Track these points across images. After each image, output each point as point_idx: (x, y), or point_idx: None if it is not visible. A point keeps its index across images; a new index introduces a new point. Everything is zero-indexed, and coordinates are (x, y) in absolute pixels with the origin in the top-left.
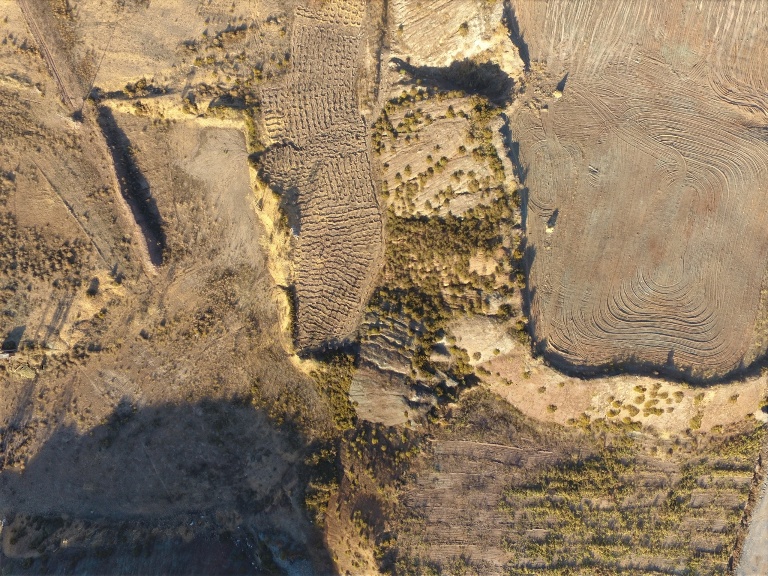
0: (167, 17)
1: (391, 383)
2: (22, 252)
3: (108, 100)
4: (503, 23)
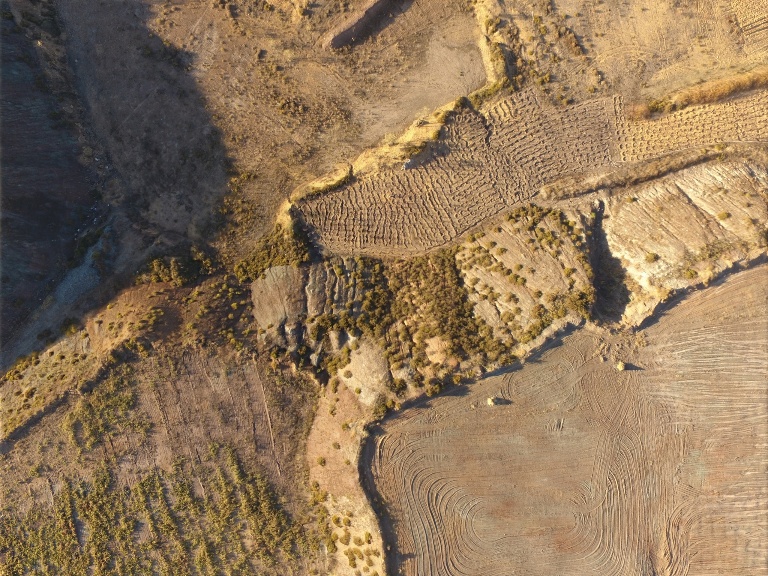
0: None
1: (295, 302)
2: None
3: None
4: (671, 292)
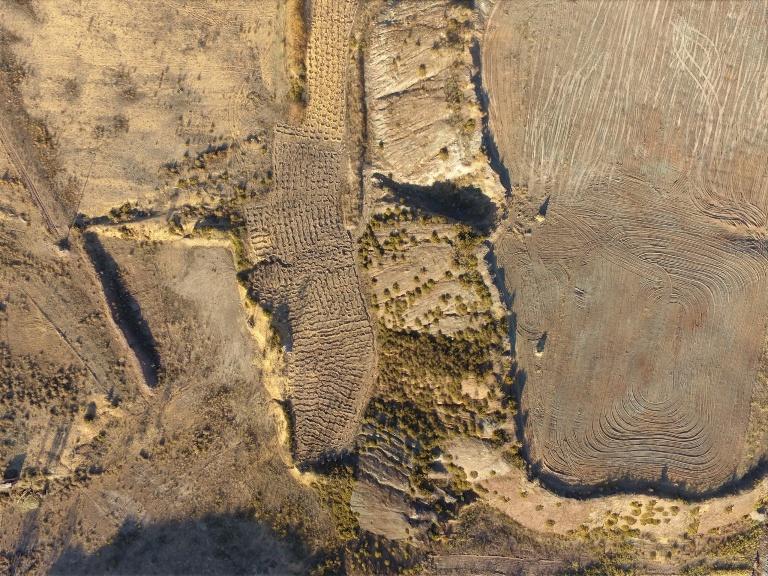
0: (147, 140)
1: (391, 500)
2: (18, 381)
3: (93, 226)
4: (482, 151)
